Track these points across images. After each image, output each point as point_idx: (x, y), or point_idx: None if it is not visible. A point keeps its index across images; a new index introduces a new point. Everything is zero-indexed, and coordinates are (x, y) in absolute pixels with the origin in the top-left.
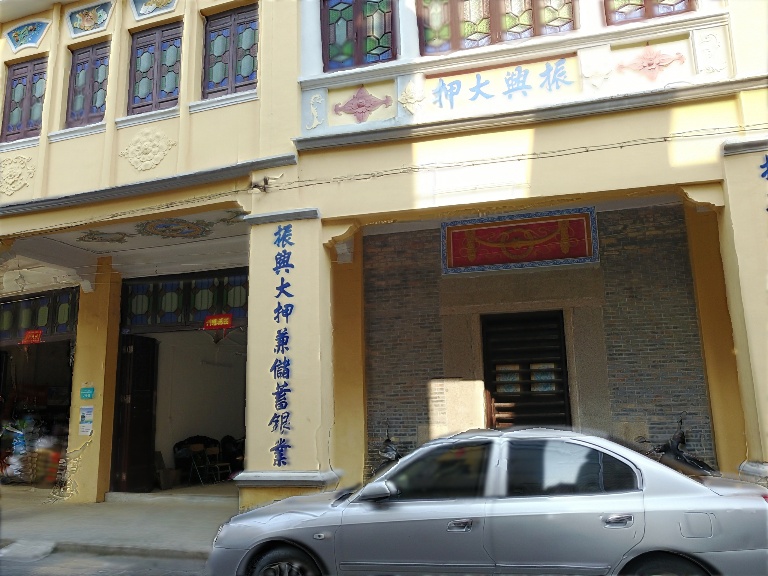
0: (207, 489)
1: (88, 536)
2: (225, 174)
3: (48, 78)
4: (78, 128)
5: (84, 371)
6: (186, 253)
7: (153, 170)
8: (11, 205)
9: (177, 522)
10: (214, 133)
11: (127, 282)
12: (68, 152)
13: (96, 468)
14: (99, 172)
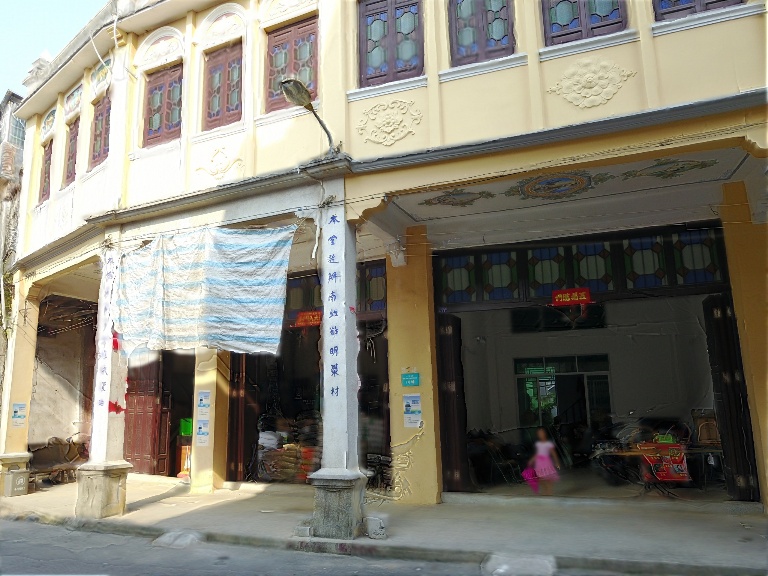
0: (542, 489)
1: (553, 546)
2: (736, 103)
3: (429, 9)
4: (478, 64)
5: (403, 354)
6: (528, 218)
7: (604, 106)
8: (411, 154)
9: (616, 529)
10: (695, 57)
11: (440, 254)
12: (468, 92)
13: (433, 464)
14: (521, 112)
